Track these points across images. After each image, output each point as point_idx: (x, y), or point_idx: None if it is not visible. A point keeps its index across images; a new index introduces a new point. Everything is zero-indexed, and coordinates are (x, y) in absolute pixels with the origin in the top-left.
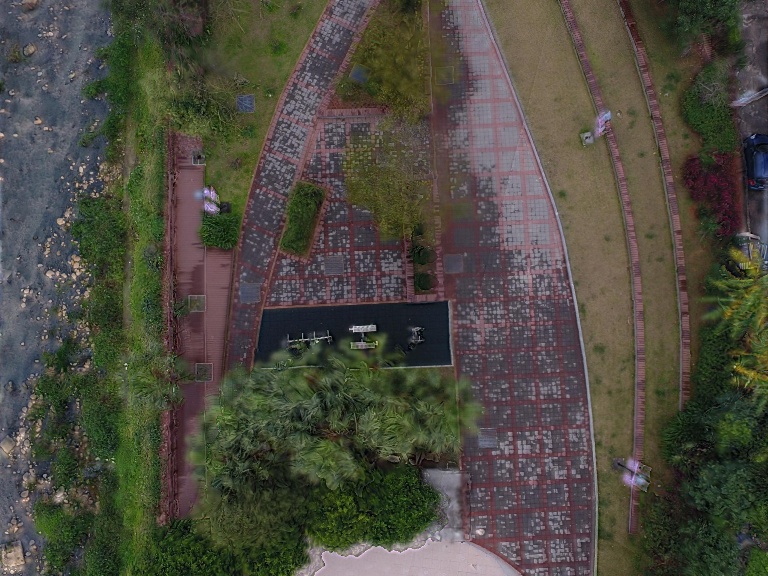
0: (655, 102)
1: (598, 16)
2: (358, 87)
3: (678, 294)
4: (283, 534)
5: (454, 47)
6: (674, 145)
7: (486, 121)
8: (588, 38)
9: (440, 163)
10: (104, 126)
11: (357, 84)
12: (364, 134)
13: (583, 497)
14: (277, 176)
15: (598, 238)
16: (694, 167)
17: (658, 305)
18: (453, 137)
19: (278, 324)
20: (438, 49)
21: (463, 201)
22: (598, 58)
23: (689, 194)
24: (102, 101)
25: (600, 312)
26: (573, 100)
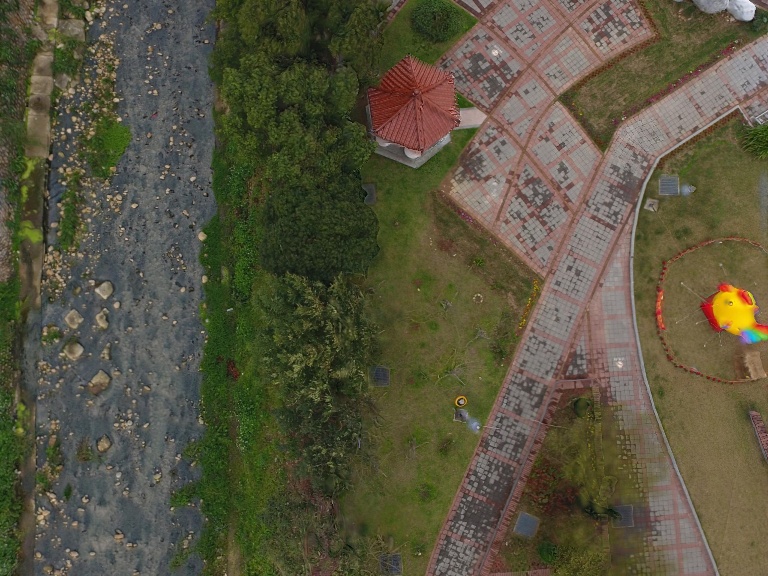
0: None
1: None
2: (525, 544)
3: None
4: None
5: (633, 481)
6: None
7: (673, 572)
8: None
9: None
10: (202, 545)
11: (524, 540)
12: None
13: None
14: None
15: None
16: None
17: None
18: None
19: None
20: None
21: None
22: None
23: None
24: (196, 508)
25: None
26: None
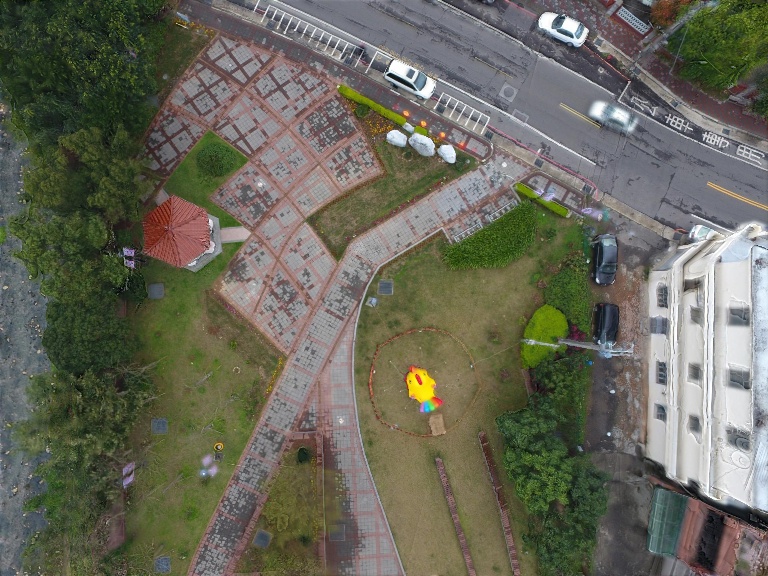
0: (516, 561)
1: (471, 479)
2: (260, 553)
3: None
4: None
5: (345, 507)
6: None
7: (372, 574)
8: (461, 500)
9: None
10: (43, 543)
11: (259, 550)
12: None
13: None
14: None
15: None
16: None
17: None
18: None
19: None
20: (332, 509)
21: None
22: (469, 518)
23: None
24: (42, 515)
25: None
26: (447, 555)
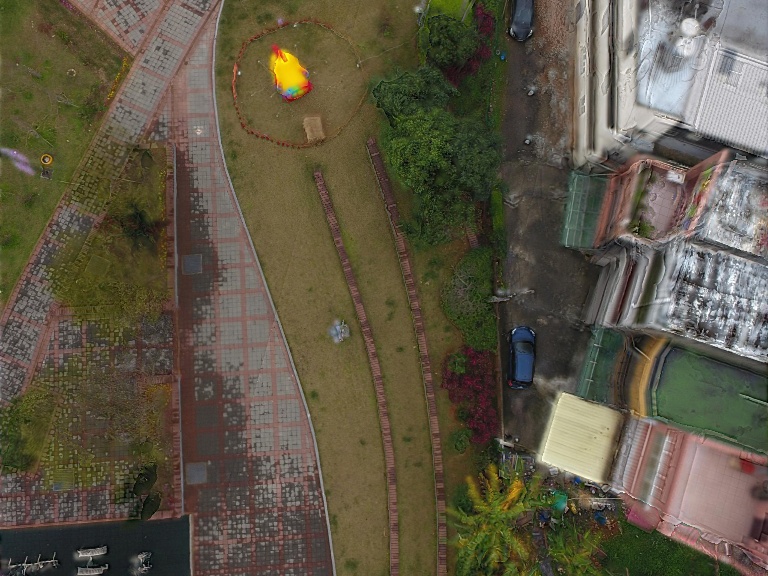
0: (414, 292)
1: (357, 197)
2: (94, 282)
3: (436, 502)
4: None
5: (203, 233)
6: (434, 339)
7: (235, 314)
8: (346, 222)
9: (184, 361)
10: None
11: (93, 279)
12: (102, 331)
13: None
14: (5, 381)
15: (353, 441)
16: (446, 369)
17: (415, 515)
18: (199, 332)
19: (0, 547)
20: (185, 236)
21: (208, 403)
22: (356, 244)
23: (448, 393)
24: None
25: (353, 524)
26: (329, 289)
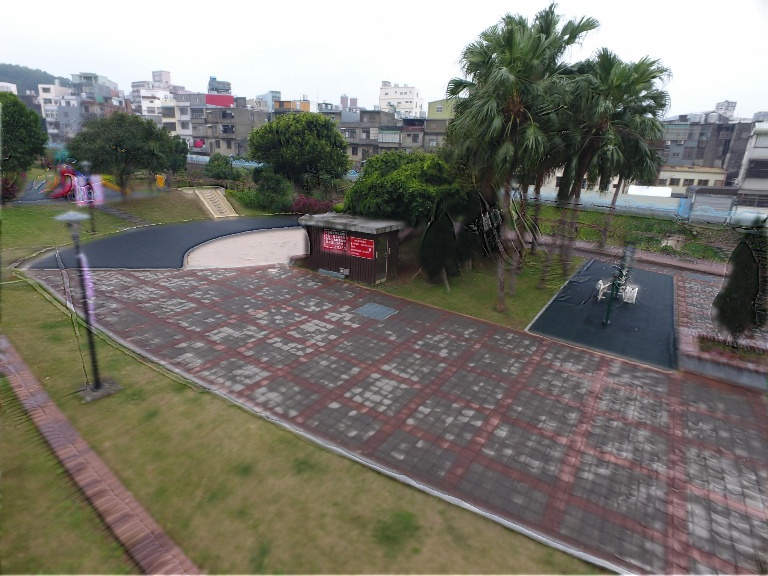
0: None
1: None
2: None
3: None
4: (466, 125)
5: None
6: None
7: None
8: None
9: None
10: None
11: None
12: None
13: (146, 335)
14: None
15: None
16: None
17: None
18: None
19: (650, 276)
20: None
21: None
22: None
23: None
24: None
25: None
26: None
